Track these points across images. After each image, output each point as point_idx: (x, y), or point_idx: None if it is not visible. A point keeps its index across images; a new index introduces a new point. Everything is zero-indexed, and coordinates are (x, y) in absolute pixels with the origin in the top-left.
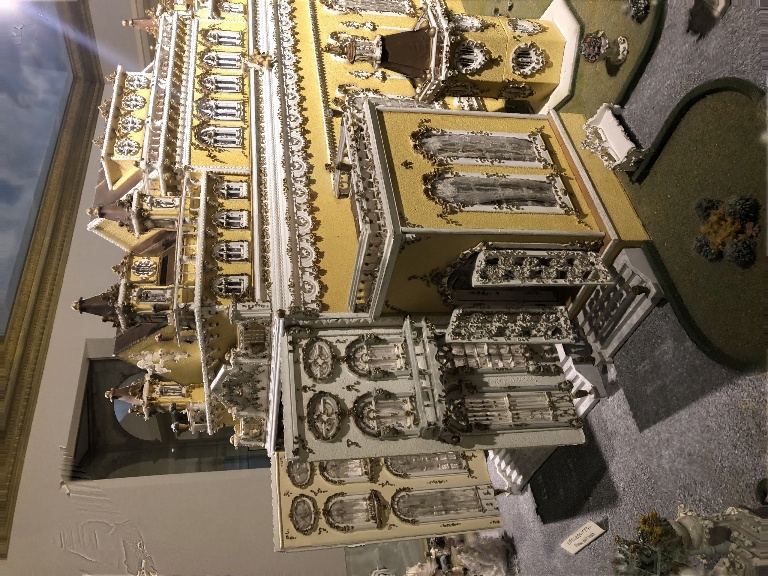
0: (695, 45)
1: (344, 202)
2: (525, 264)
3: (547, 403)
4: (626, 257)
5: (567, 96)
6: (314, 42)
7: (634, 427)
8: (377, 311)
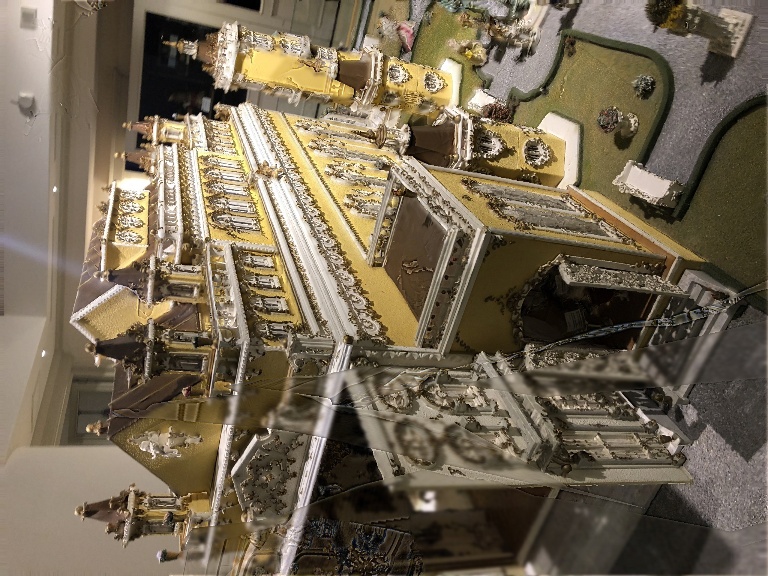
0: (713, 90)
1: (379, 269)
2: (605, 274)
3: (639, 443)
4: (692, 275)
5: (575, 183)
6: (314, 168)
7: (737, 459)
8: (448, 344)
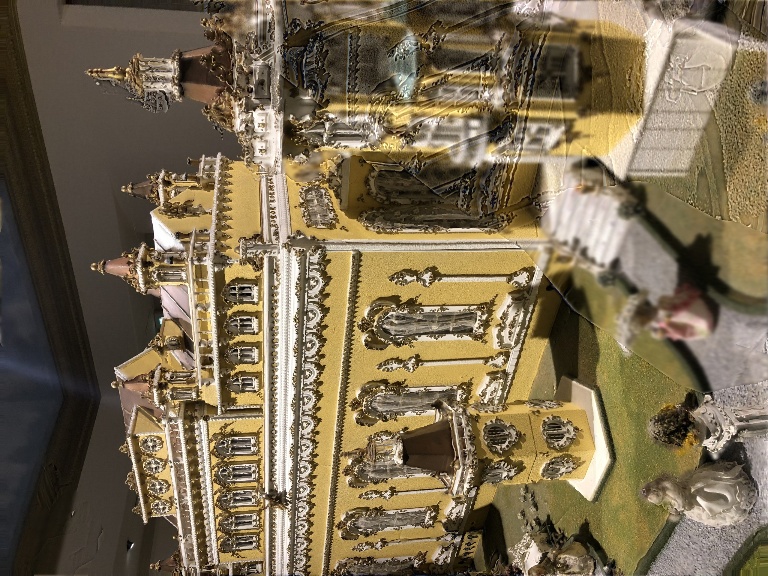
0: None
1: None
2: None
3: None
4: None
5: None
6: (332, 471)
7: None
8: None
